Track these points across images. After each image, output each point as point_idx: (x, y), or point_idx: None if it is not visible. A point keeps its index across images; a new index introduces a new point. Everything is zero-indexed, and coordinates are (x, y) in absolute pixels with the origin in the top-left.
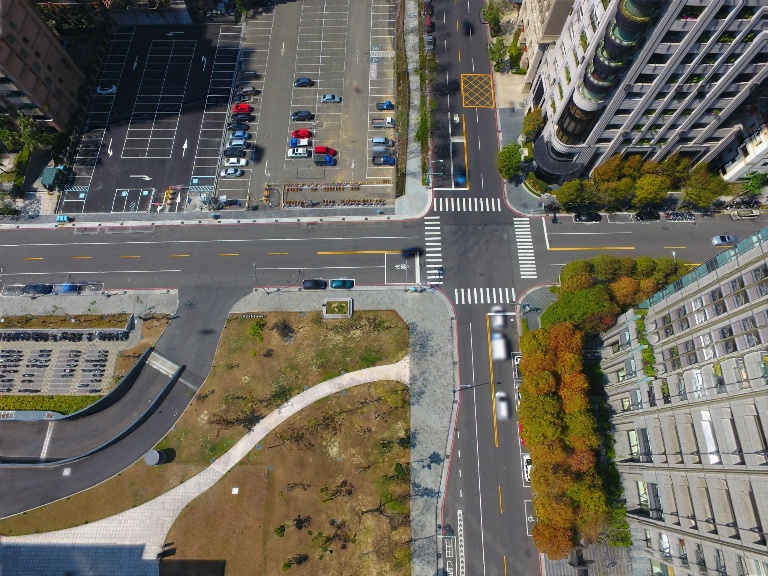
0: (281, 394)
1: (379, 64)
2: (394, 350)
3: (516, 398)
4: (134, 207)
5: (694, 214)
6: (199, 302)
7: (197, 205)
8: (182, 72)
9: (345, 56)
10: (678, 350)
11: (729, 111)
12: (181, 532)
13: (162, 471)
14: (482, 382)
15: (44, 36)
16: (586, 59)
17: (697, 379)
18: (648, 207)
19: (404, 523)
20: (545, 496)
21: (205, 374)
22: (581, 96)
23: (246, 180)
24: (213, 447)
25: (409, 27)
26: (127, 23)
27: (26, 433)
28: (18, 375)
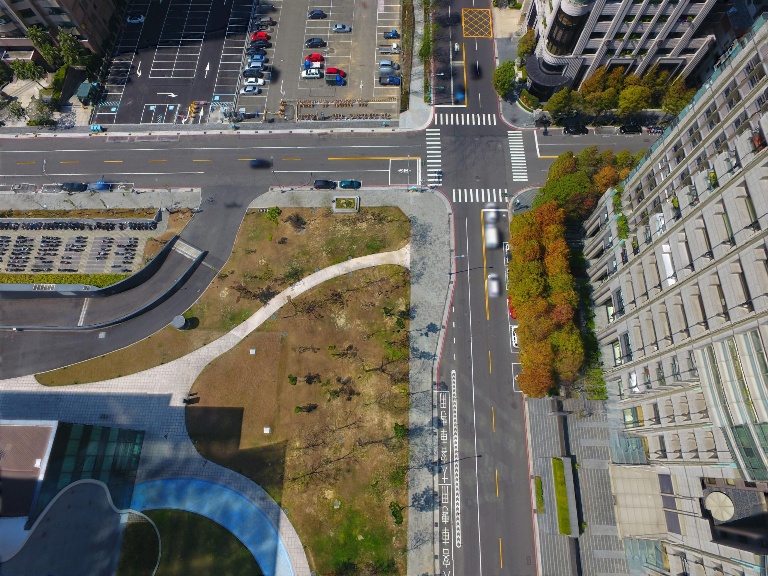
0: (294, 275)
1: None
2: (396, 239)
3: (506, 279)
4: (161, 119)
5: None
6: (220, 199)
7: (218, 118)
8: (205, 5)
9: None
10: (647, 211)
11: (701, 18)
12: (204, 385)
13: (187, 335)
14: (476, 266)
15: None
16: None
17: (660, 221)
18: (631, 122)
19: (403, 380)
20: (528, 343)
21: (225, 258)
22: (567, 1)
23: (263, 97)
24: (233, 317)
25: None
26: None
27: (64, 307)
28: (57, 258)
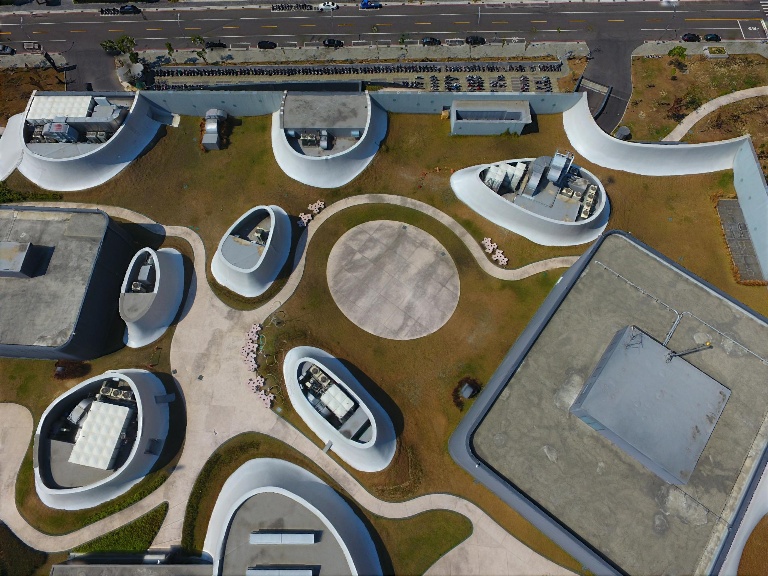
0: (694, 102)
1: None
2: None
3: None
4: None
5: None
6: (605, 49)
7: None
8: None
9: None
10: None
11: None
12: None
13: None
14: None
15: None
16: None
17: None
18: None
19: None
20: None
21: (629, 92)
22: None
23: None
24: (658, 131)
25: None
26: None
27: None
28: None
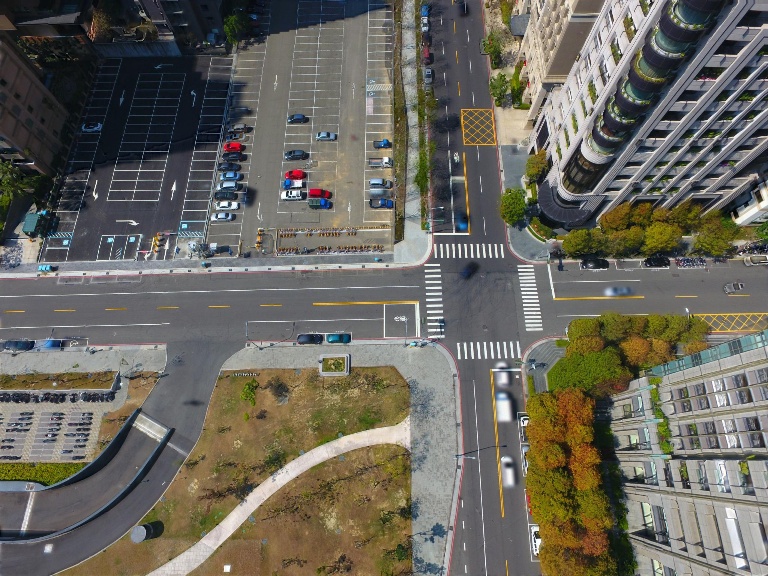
0: (275, 460)
1: (376, 98)
2: (394, 411)
3: (523, 463)
4: (120, 255)
5: (705, 260)
6: (189, 358)
7: (186, 252)
8: (171, 108)
9: (340, 90)
10: (697, 429)
11: (745, 163)
12: None
13: (149, 547)
14: (487, 445)
15: (24, 76)
16: (595, 112)
17: (720, 471)
18: (658, 253)
19: None
20: None
21: (195, 438)
22: (590, 149)
23: (238, 225)
24: (203, 519)
25: (407, 59)
26: (113, 55)
27: (6, 503)
28: None
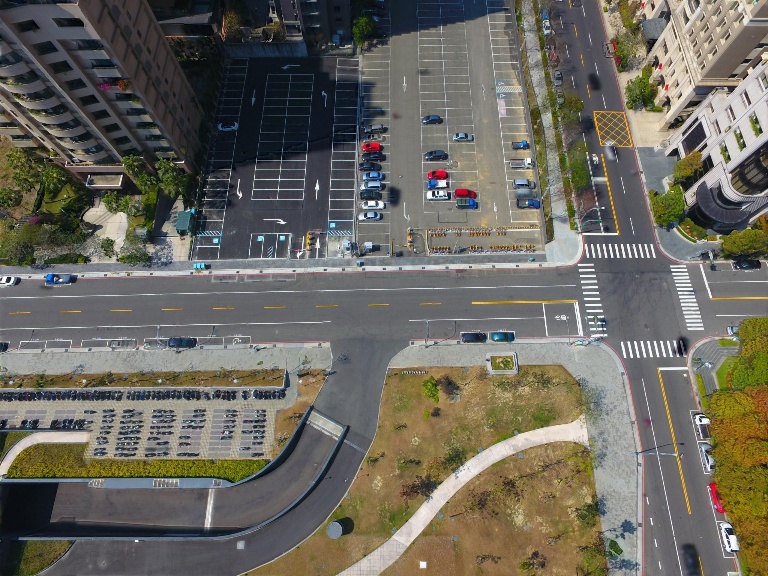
0: (455, 457)
1: (507, 100)
2: (567, 408)
3: (703, 460)
4: (272, 253)
5: None
6: (354, 356)
7: None
8: (303, 108)
9: (470, 91)
10: None
11: None
12: None
13: (342, 543)
14: (664, 443)
15: (178, 75)
16: None
17: None
18: None
19: None
20: None
21: (371, 435)
22: None
23: (386, 224)
24: (392, 516)
25: (533, 61)
26: (240, 56)
27: (186, 500)
28: (173, 437)
